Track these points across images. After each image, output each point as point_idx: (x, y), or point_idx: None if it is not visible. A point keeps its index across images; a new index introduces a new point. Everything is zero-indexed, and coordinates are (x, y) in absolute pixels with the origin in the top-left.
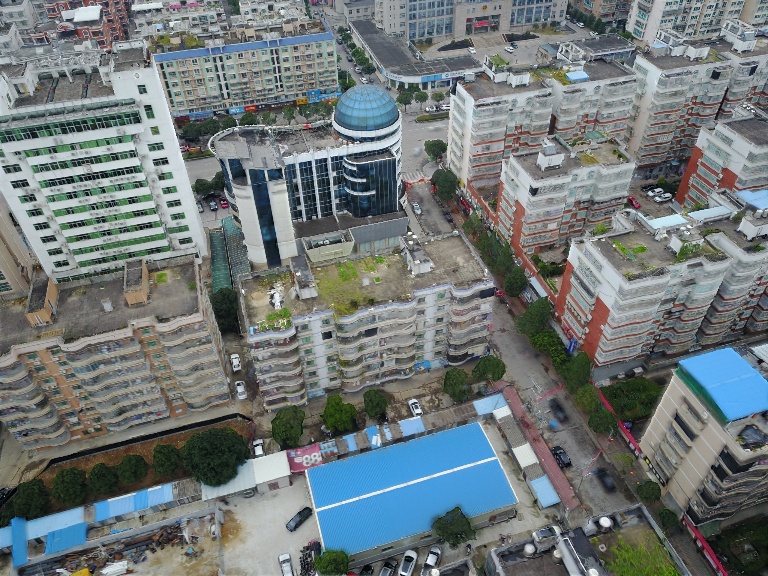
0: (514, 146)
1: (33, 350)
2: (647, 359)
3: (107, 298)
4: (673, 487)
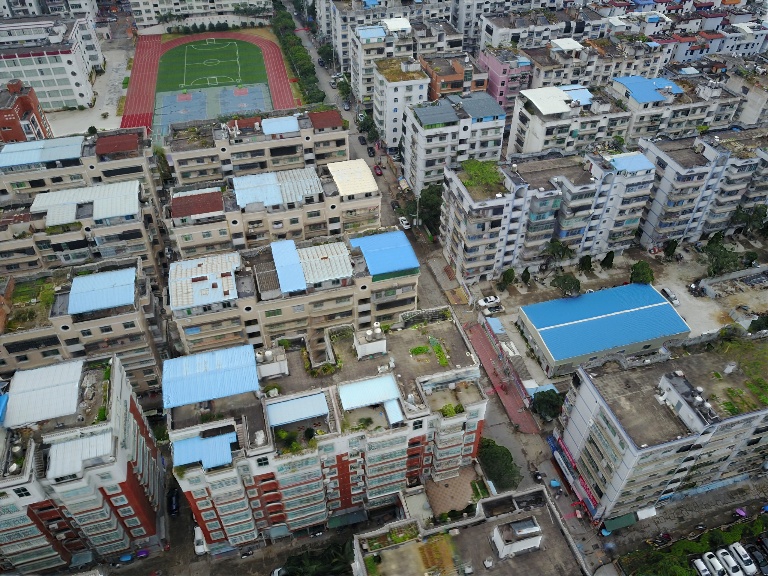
0: None
1: None
2: None
3: None
4: None
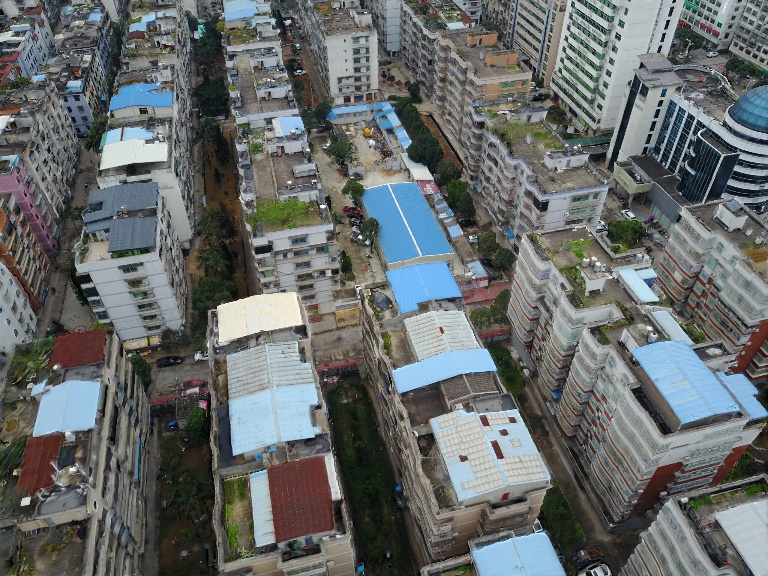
0: None
1: None
2: (535, 371)
3: None
4: None
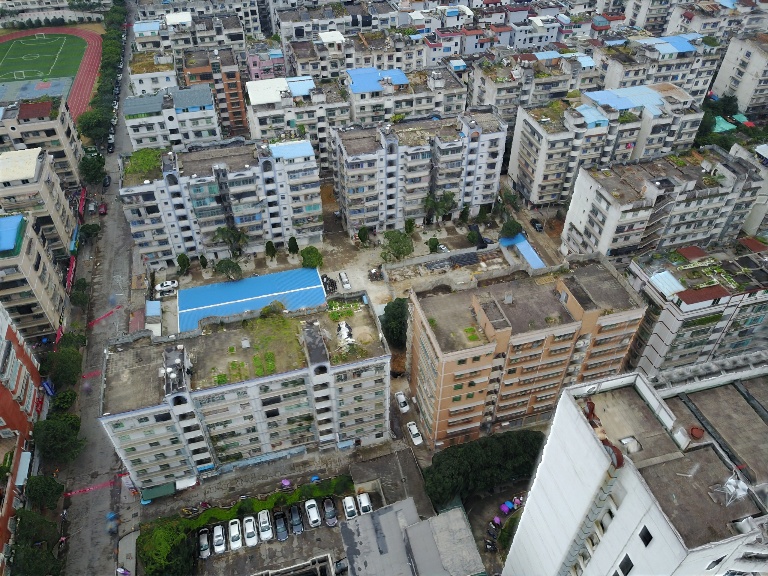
0: None
1: None
2: None
3: (508, 294)
4: None
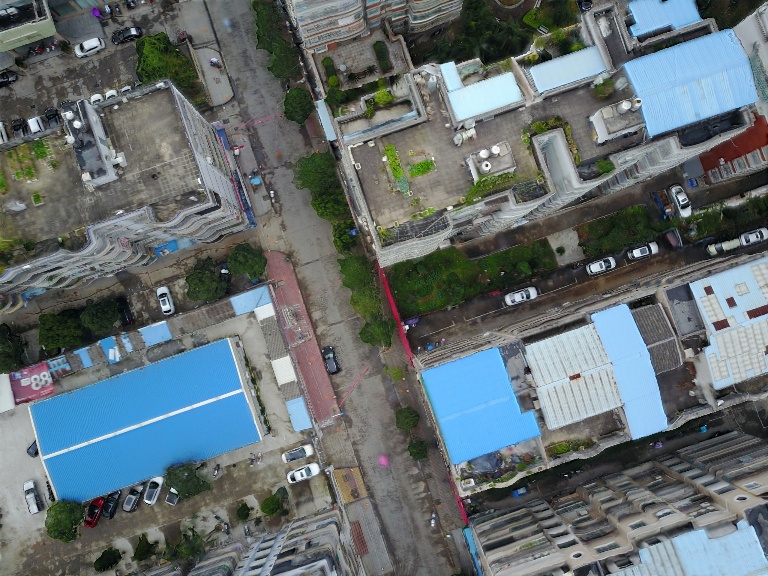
0: None
1: None
2: (455, 236)
3: None
4: None
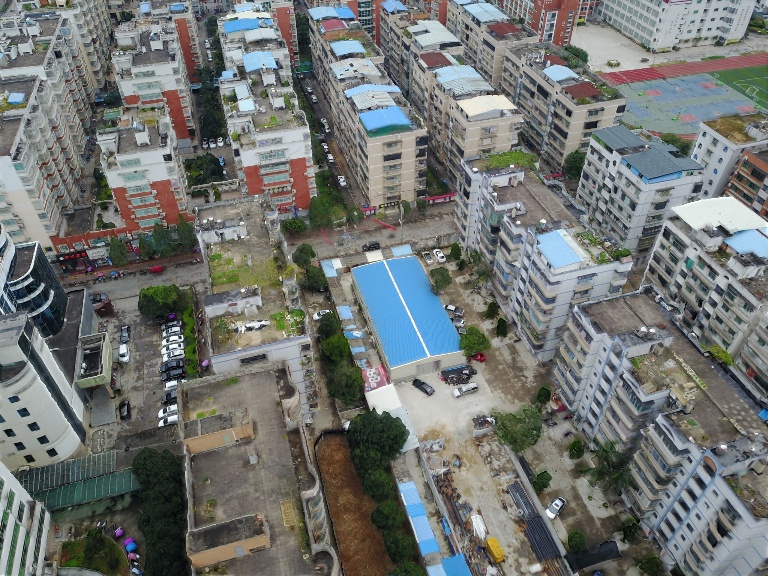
0: (45, 183)
1: (311, 533)
2: None
3: (248, 448)
4: (403, 197)
